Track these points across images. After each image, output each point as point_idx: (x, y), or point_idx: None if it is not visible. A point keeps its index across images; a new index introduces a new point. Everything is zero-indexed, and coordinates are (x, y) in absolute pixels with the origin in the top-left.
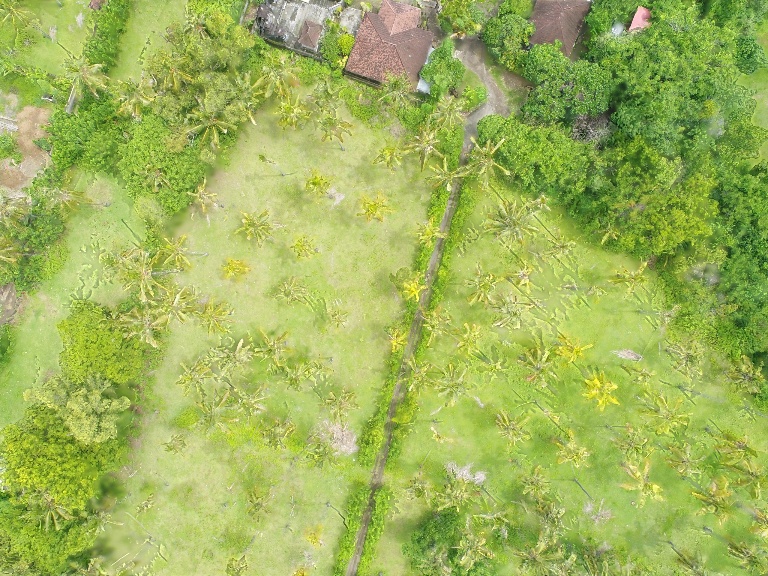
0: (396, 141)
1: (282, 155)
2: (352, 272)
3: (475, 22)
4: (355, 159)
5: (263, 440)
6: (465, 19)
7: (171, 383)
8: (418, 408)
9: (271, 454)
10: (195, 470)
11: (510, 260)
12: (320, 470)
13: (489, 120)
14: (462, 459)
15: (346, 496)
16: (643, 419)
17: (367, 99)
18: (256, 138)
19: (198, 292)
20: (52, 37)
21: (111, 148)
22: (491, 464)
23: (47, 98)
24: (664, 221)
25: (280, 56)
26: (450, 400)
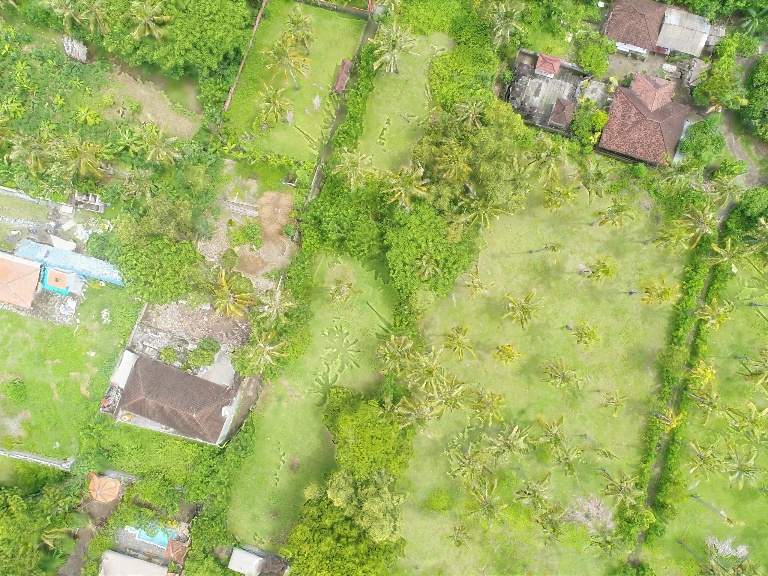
0: (646, 214)
1: (528, 232)
2: (604, 348)
3: (741, 97)
4: (604, 234)
5: (548, 529)
6: (733, 95)
7: (419, 465)
8: (685, 486)
9: (524, 534)
10: (445, 552)
11: (767, 331)
12: (575, 549)
13: (756, 194)
14: (723, 534)
15: (603, 574)
16: None
17: (615, 173)
18: (501, 216)
19: (447, 373)
20: (289, 120)
21: (376, 237)
22: (752, 537)
23: (288, 183)
24: None
25: (529, 134)
26: (738, 483)
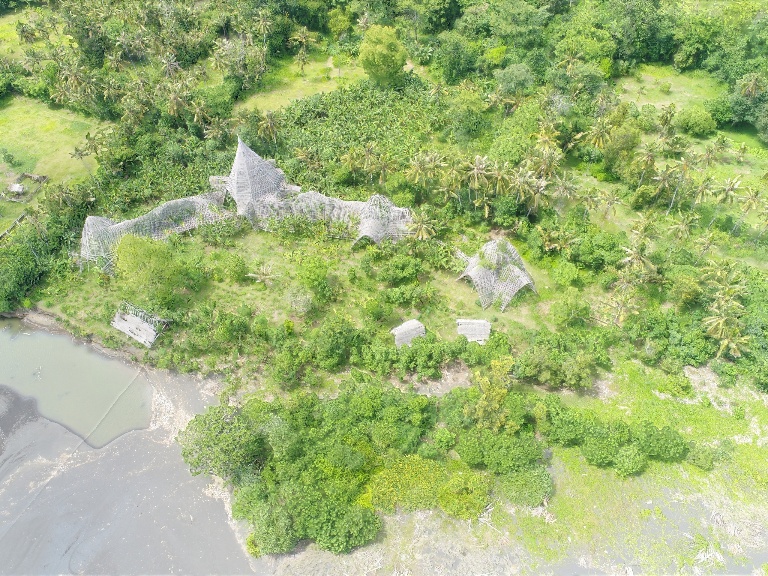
0: None
1: None
2: None
3: None
4: None
5: None
6: None
7: None
8: None
9: None
10: None
11: None
12: None
13: None
14: None
15: None
16: (691, 1)
17: None
18: None
19: None
20: None
21: None
22: None
23: None
24: (754, 6)
25: None
26: None
